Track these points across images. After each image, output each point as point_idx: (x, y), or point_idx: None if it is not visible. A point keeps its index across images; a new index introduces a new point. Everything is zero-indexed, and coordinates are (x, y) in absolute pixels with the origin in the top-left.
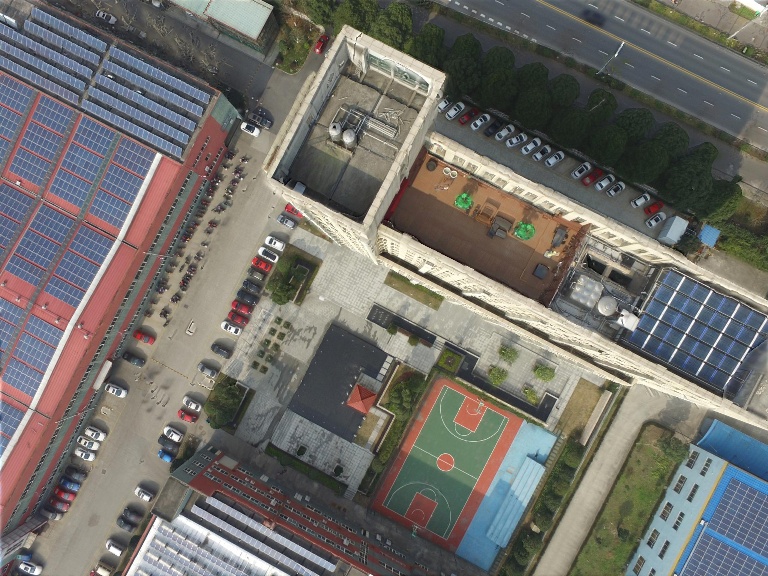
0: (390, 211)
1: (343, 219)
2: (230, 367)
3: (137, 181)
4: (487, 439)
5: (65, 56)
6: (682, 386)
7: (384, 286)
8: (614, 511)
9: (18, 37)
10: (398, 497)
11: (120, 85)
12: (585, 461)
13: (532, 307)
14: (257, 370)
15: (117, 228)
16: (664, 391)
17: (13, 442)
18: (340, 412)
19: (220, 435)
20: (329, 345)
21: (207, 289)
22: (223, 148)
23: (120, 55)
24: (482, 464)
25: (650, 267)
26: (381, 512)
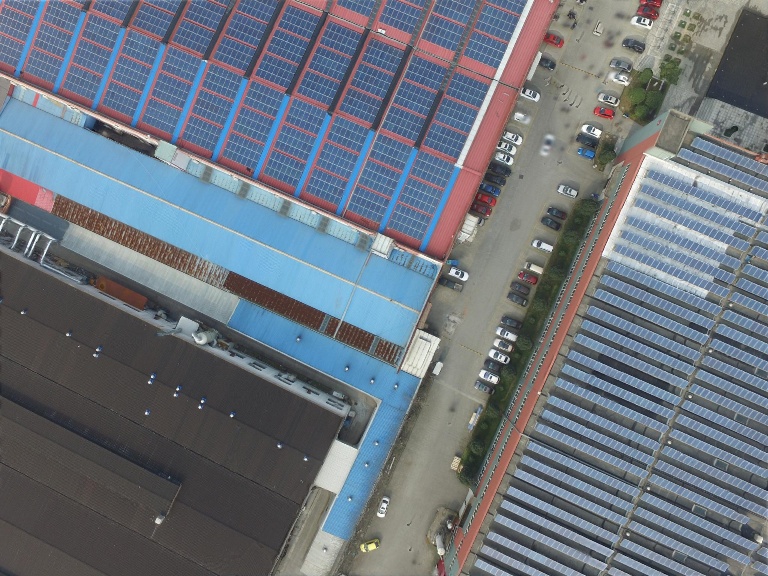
0: None
1: None
2: (641, 63)
3: None
4: None
5: None
6: None
7: None
8: None
9: None
10: None
11: None
12: None
13: None
14: None
15: None
16: None
17: (482, 112)
18: (762, 93)
19: None
20: (744, 29)
21: None
22: None
23: None
24: None
25: None
26: None
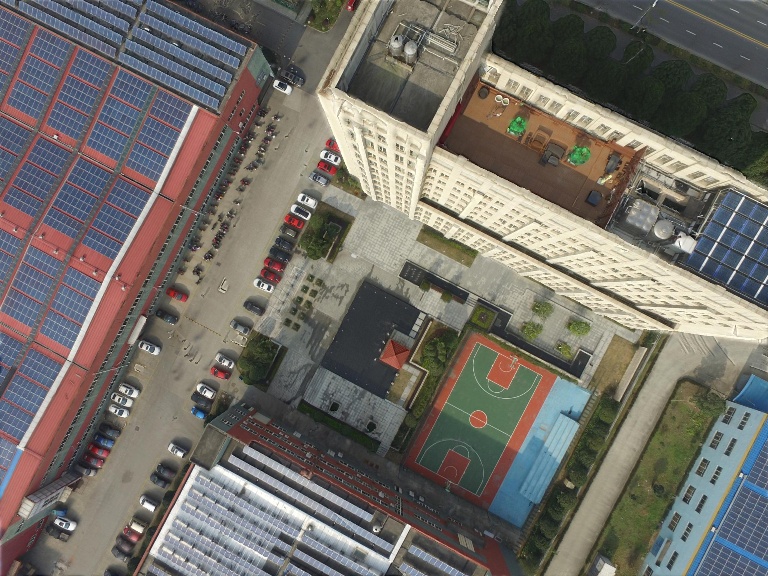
0: (444, 135)
1: (407, 128)
2: (262, 324)
3: (174, 134)
4: (520, 396)
5: (102, 9)
6: (741, 307)
7: (416, 243)
8: (648, 468)
9: None
10: (431, 454)
11: (157, 38)
12: (619, 418)
13: (589, 228)
14: (289, 327)
15: (154, 181)
16: (709, 333)
17: (51, 393)
18: (373, 369)
19: (253, 392)
20: (361, 302)
21: (239, 247)
22: (256, 105)
23: (157, 8)
24: (515, 421)
25: (705, 193)
26: (414, 469)
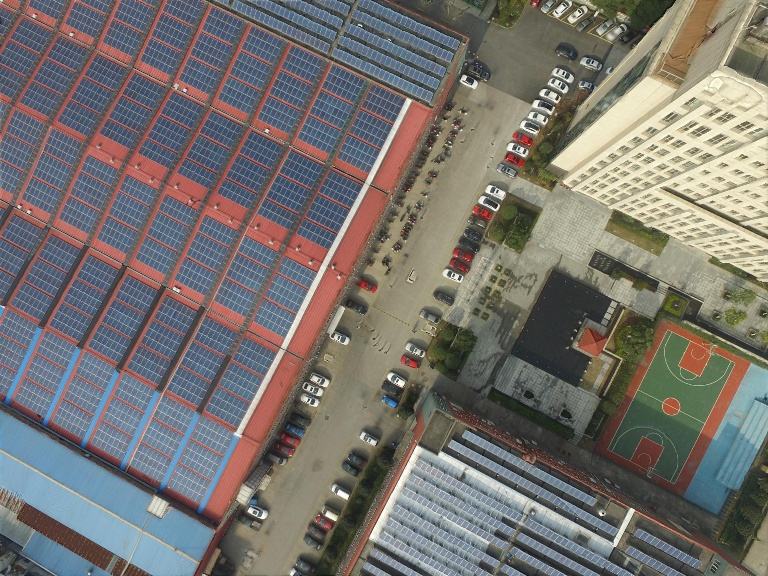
0: None
1: None
2: (451, 314)
3: (386, 126)
4: (713, 383)
5: (316, 7)
6: None
7: (605, 233)
8: None
9: None
10: (624, 441)
11: (371, 33)
12: None
13: None
14: (478, 317)
15: (365, 172)
16: None
17: (267, 381)
18: (564, 357)
19: (442, 381)
20: (552, 291)
21: (427, 238)
22: (445, 100)
23: (369, 5)
24: (708, 408)
25: None
26: (607, 456)
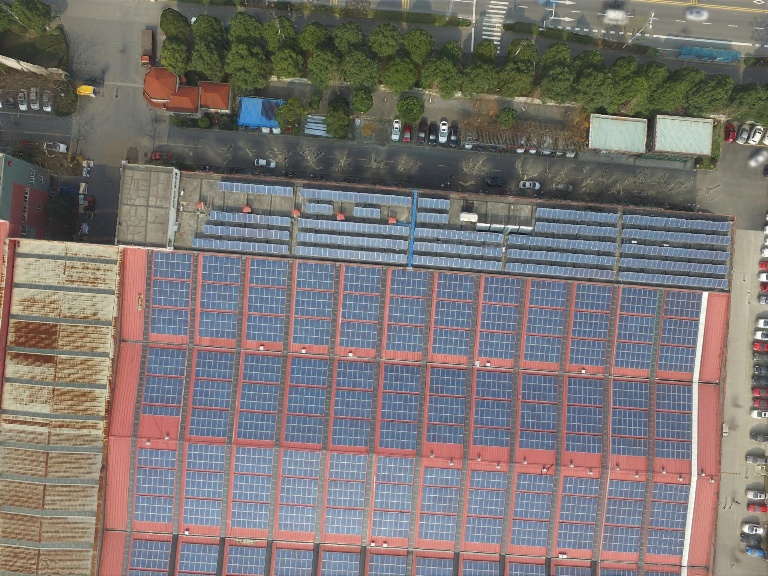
0: None
1: None
2: None
3: (693, 324)
4: None
5: (587, 241)
6: None
7: None
8: None
9: (535, 241)
10: None
11: (649, 246)
12: None
13: None
14: None
15: (689, 373)
16: None
17: None
18: None
19: None
20: None
21: None
22: None
23: (635, 219)
24: None
25: None
26: None
